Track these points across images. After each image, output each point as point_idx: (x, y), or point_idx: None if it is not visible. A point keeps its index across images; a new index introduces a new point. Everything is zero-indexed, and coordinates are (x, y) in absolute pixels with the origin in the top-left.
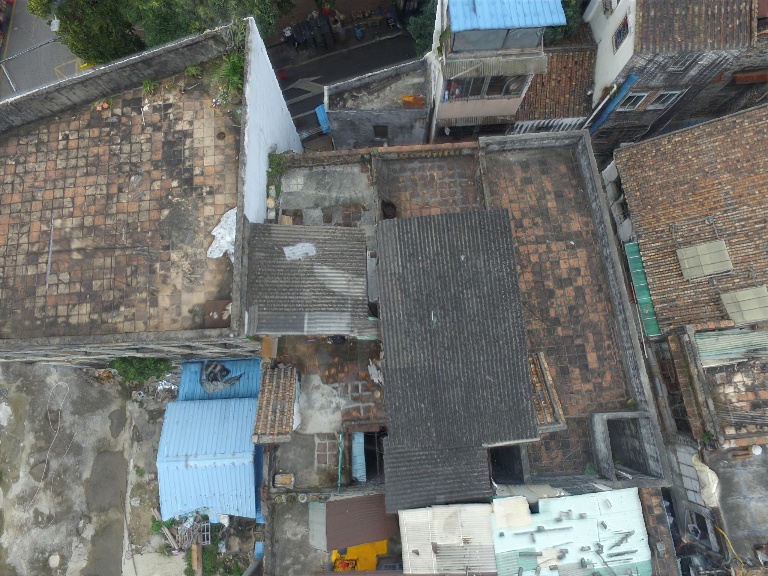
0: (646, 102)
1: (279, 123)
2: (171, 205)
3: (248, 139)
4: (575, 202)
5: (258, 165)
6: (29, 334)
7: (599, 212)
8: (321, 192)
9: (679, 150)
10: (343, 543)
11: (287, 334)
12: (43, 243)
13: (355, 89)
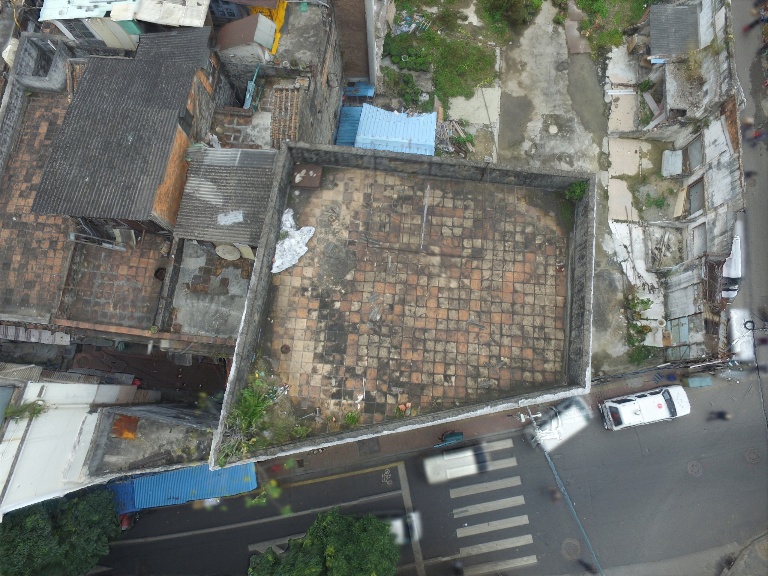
0: None
1: None
2: (343, 283)
3: None
4: None
5: None
6: (478, 188)
7: None
8: (225, 311)
9: None
10: (249, 19)
11: (254, 150)
12: (467, 267)
13: (183, 462)
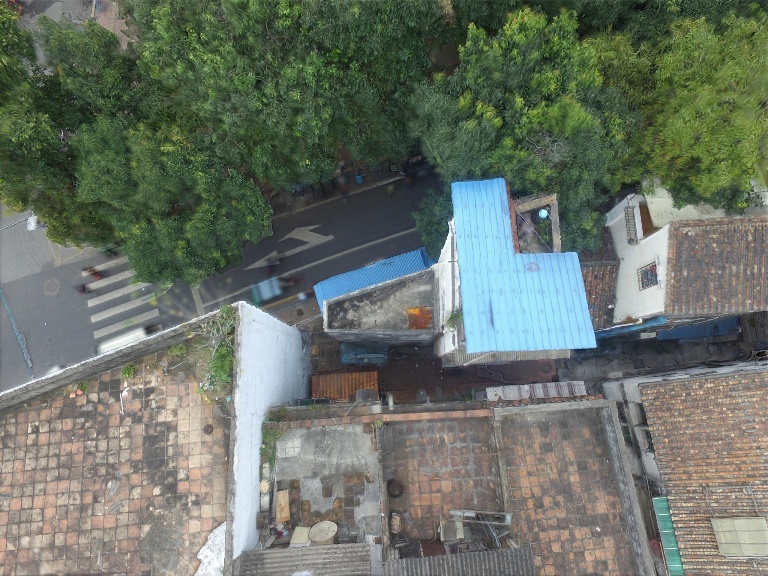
0: (672, 320)
1: (274, 360)
2: (152, 519)
3: (238, 459)
4: (600, 476)
5: (250, 463)
6: None
7: (628, 501)
8: (320, 457)
9: (712, 399)
10: None
11: None
12: (9, 567)
13: (356, 297)
